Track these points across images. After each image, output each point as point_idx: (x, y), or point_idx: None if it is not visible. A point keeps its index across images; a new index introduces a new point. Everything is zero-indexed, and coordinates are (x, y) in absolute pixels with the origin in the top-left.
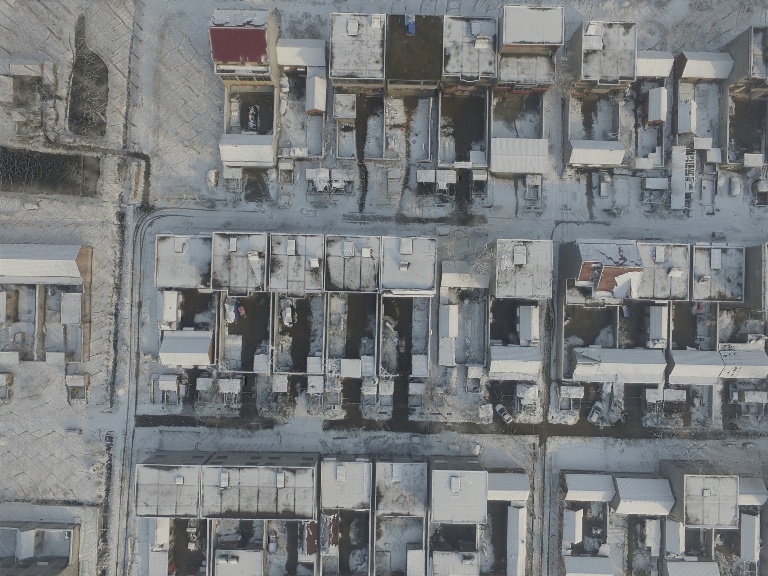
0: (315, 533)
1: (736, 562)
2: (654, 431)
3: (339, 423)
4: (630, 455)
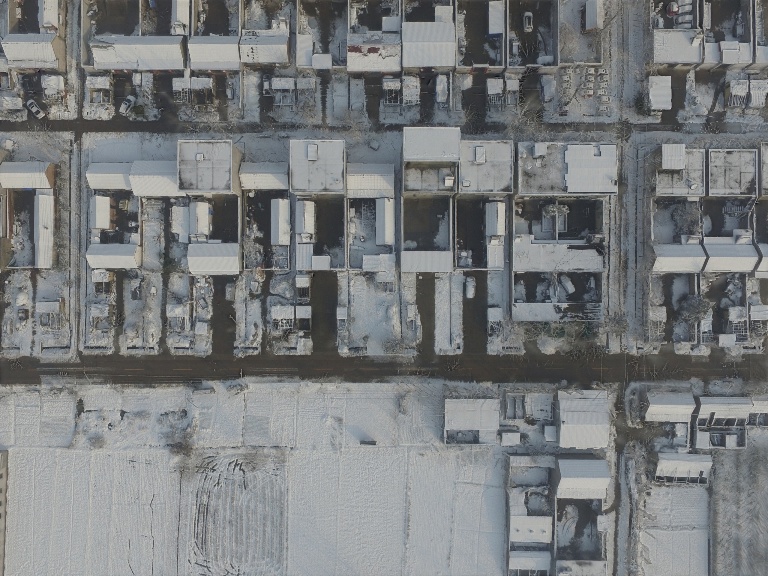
0: None
1: (276, 254)
2: (190, 125)
3: None
4: (166, 149)
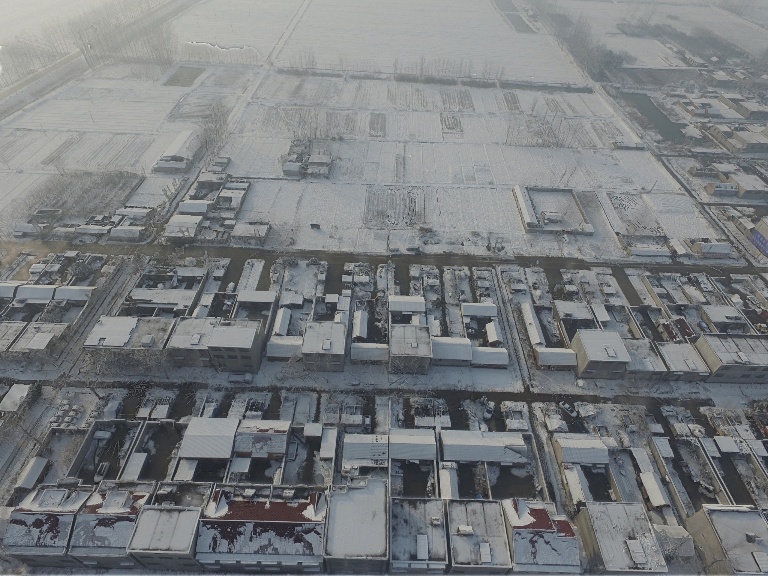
0: (683, 331)
1: None
2: (435, 395)
3: (702, 404)
4: (453, 378)
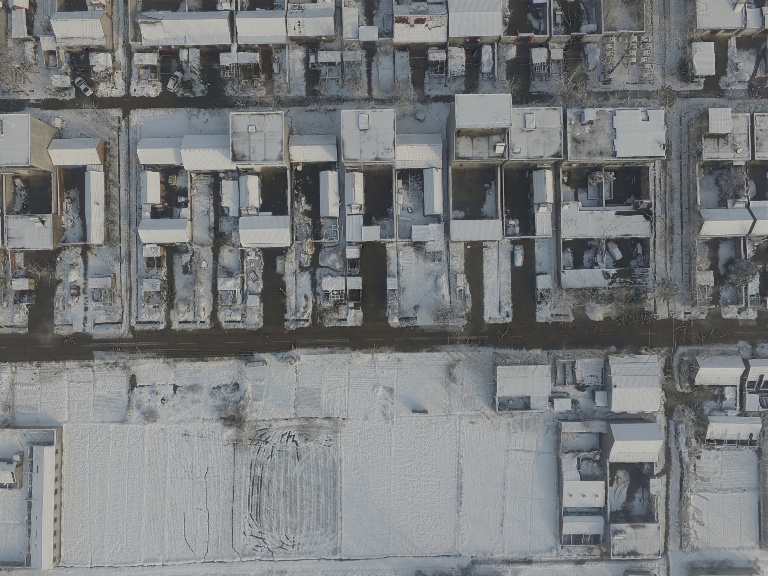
0: None
1: (324, 226)
2: (237, 100)
3: None
4: (213, 124)
